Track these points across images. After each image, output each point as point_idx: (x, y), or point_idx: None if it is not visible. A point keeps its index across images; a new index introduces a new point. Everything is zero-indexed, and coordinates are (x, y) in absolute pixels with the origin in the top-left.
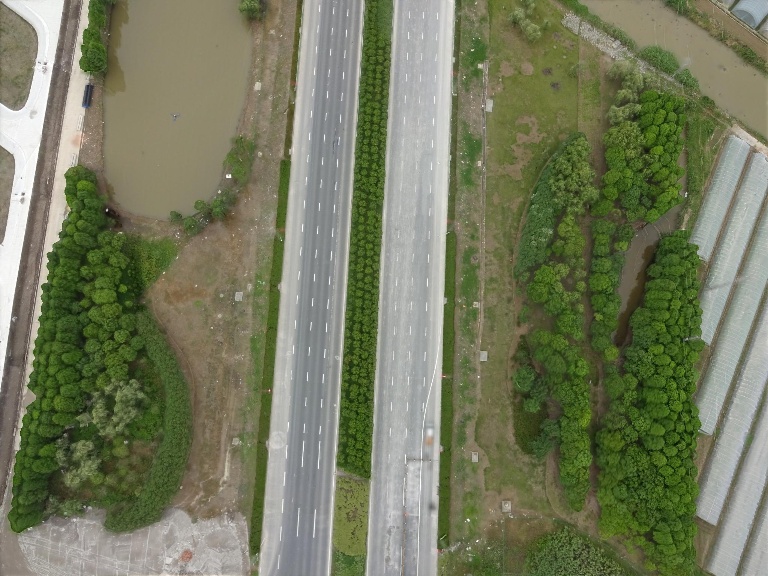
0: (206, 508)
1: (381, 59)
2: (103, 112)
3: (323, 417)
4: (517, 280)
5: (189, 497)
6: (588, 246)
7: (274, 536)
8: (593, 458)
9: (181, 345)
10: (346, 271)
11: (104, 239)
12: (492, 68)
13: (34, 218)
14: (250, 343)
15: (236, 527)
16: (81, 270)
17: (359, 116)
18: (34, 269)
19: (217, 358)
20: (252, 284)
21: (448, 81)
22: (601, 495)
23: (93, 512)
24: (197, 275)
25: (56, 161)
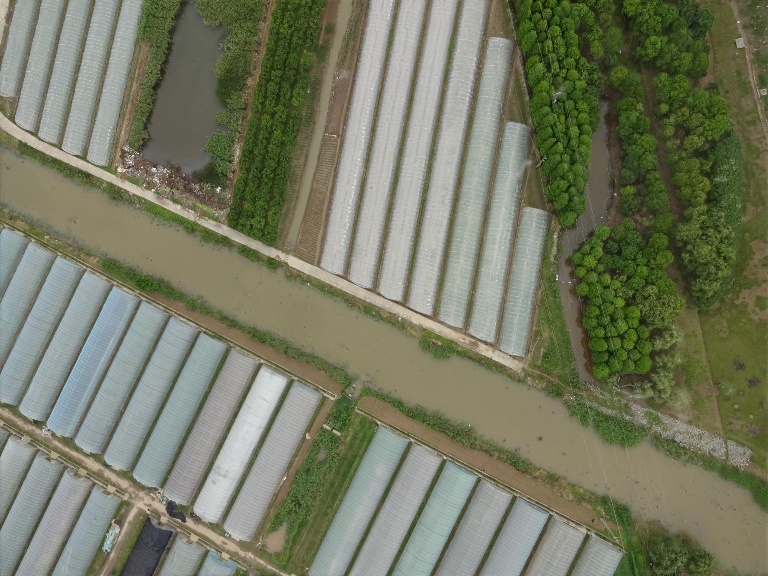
0: None
1: None
2: None
3: None
4: None
5: None
6: None
7: None
8: None
9: None
10: None
11: None
12: None
13: None
14: None
15: None
16: None
17: None
18: None
19: None
20: None
21: None
22: None
23: None
24: None
25: None
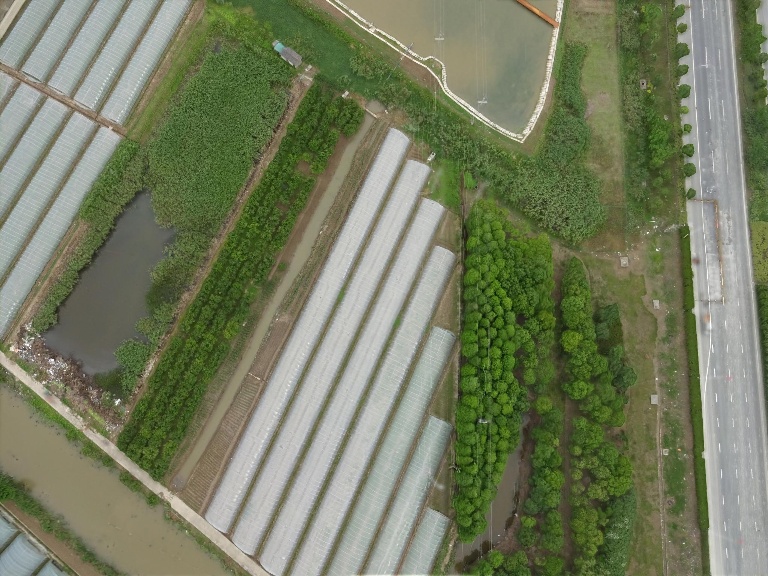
0: None
1: None
2: None
3: None
4: None
5: None
6: None
7: None
8: None
9: None
10: None
11: None
12: None
13: None
14: None
15: None
16: None
17: None
18: None
19: None
20: None
21: None
22: None
23: None
24: None
25: None
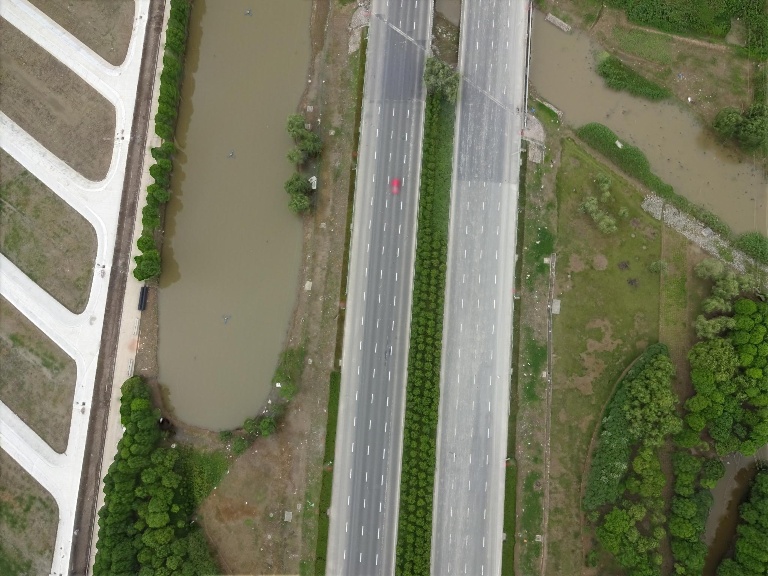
0: None
1: (436, 263)
2: (158, 315)
3: None
4: (585, 513)
5: None
6: (669, 476)
7: None
8: None
9: (231, 566)
10: (398, 498)
11: (157, 459)
12: (560, 262)
13: (94, 427)
14: (299, 568)
15: None
16: (135, 492)
17: (412, 327)
18: (94, 480)
19: None
20: (302, 504)
21: (510, 282)
22: None
23: None
24: (247, 491)
25: (114, 366)
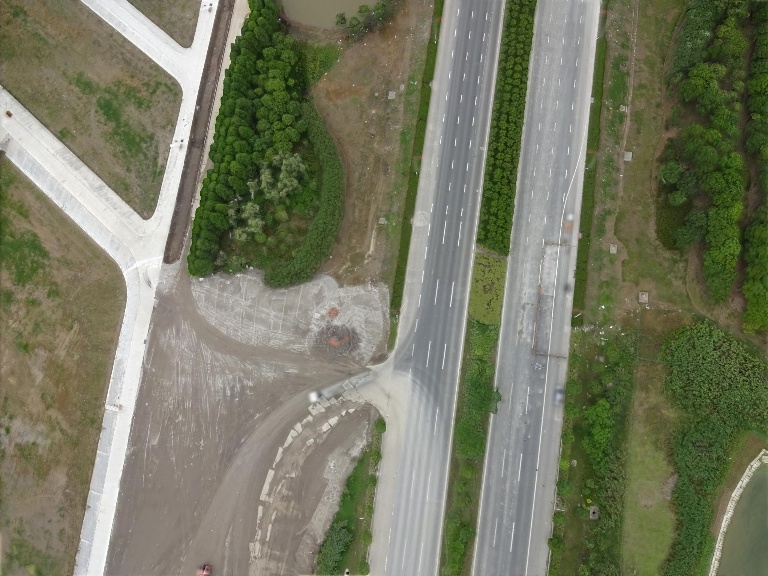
0: (352, 277)
1: None
2: None
3: (465, 201)
4: (667, 85)
5: (337, 266)
6: (746, 54)
7: (413, 302)
8: (740, 254)
9: (338, 136)
10: (495, 72)
11: (278, 37)
12: None
13: (218, 26)
14: (400, 136)
15: (379, 293)
16: (257, 62)
17: None
18: (216, 68)
19: (369, 148)
20: (405, 85)
21: None
22: (748, 286)
23: (254, 271)
24: (355, 76)
25: None
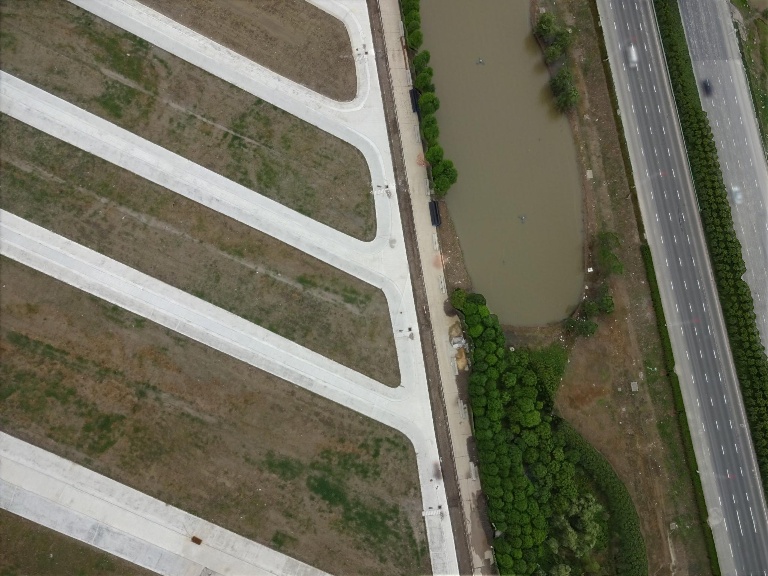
0: None
1: (706, 132)
2: (453, 227)
3: (746, 484)
4: None
5: None
6: None
7: None
8: None
9: (598, 446)
10: (726, 342)
11: (515, 361)
12: None
13: (424, 351)
14: (658, 429)
15: None
16: (504, 397)
17: (701, 191)
18: (440, 404)
19: (633, 451)
20: (643, 372)
21: (757, 142)
22: None
23: None
24: (592, 374)
25: (424, 287)
